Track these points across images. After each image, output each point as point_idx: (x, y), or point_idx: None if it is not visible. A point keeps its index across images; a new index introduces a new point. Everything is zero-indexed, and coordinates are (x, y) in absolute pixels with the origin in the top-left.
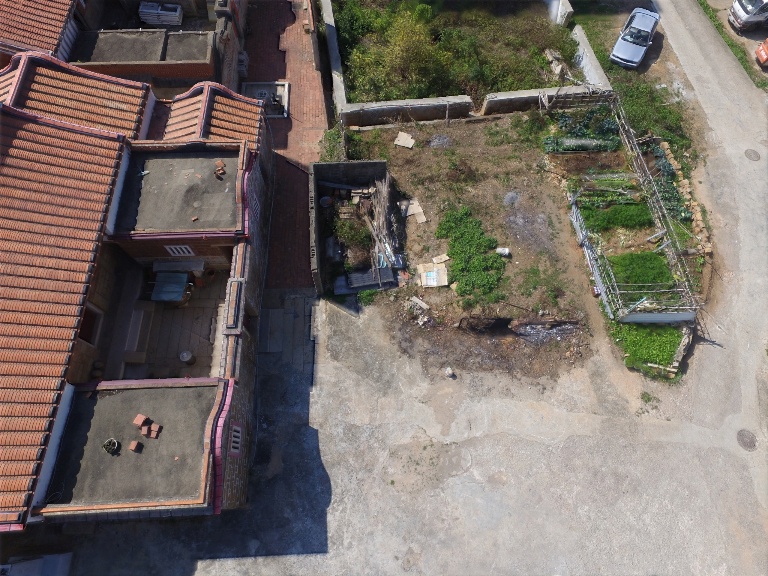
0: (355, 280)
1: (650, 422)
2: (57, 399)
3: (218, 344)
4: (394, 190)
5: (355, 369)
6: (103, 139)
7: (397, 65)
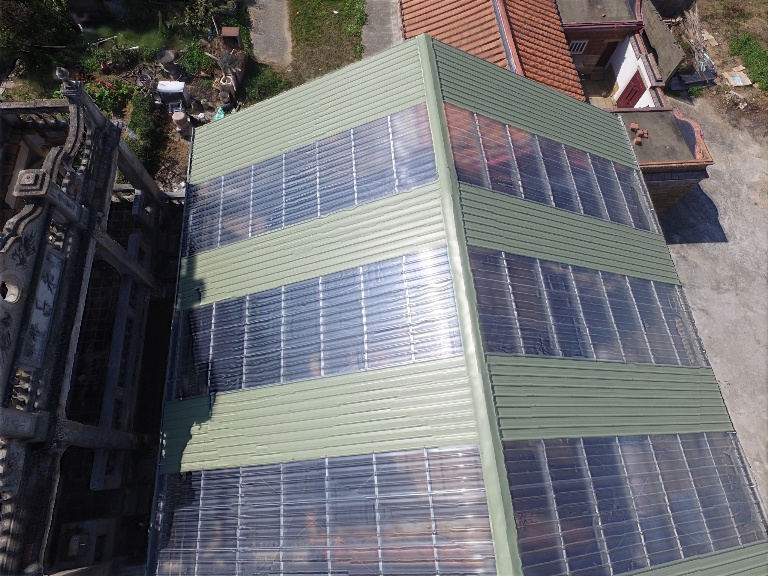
0: (687, 79)
1: None
2: None
3: None
4: None
5: None
6: None
7: None
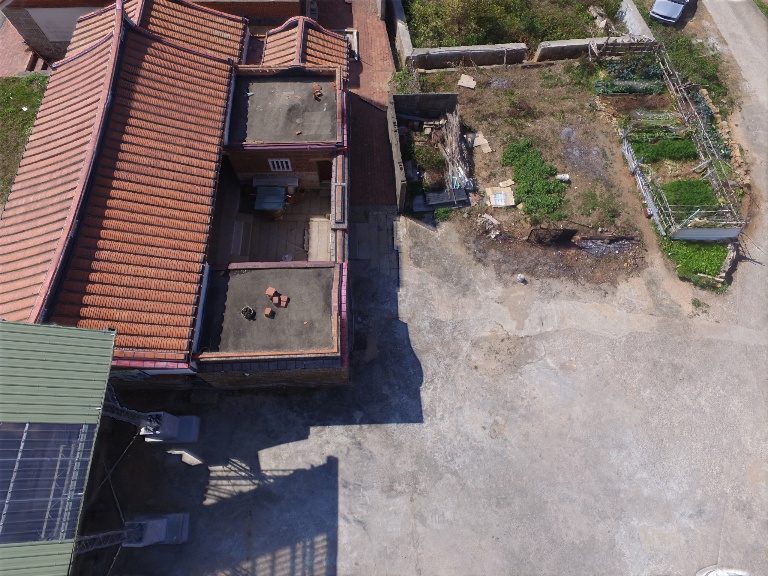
0: (432, 198)
1: (701, 323)
2: (202, 270)
3: (312, 252)
4: (460, 125)
5: (436, 274)
6: (216, 61)
7: (459, 14)
